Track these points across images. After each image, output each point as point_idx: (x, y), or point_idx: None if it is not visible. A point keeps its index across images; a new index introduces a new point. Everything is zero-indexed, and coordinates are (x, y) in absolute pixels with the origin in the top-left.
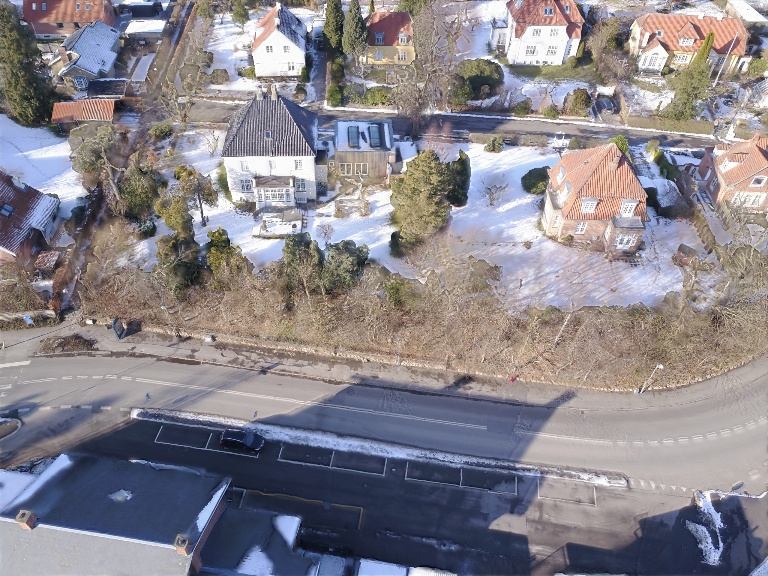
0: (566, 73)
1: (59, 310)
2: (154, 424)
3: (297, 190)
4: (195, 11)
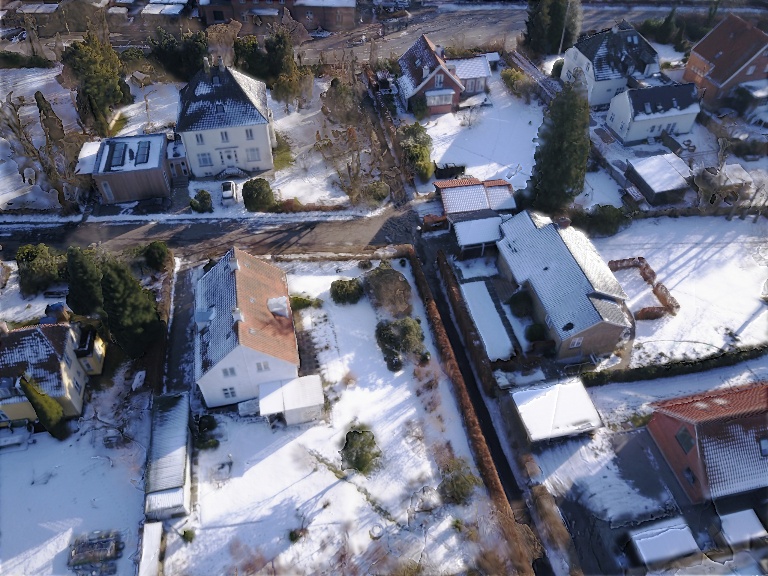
0: None
1: None
2: None
3: None
4: None
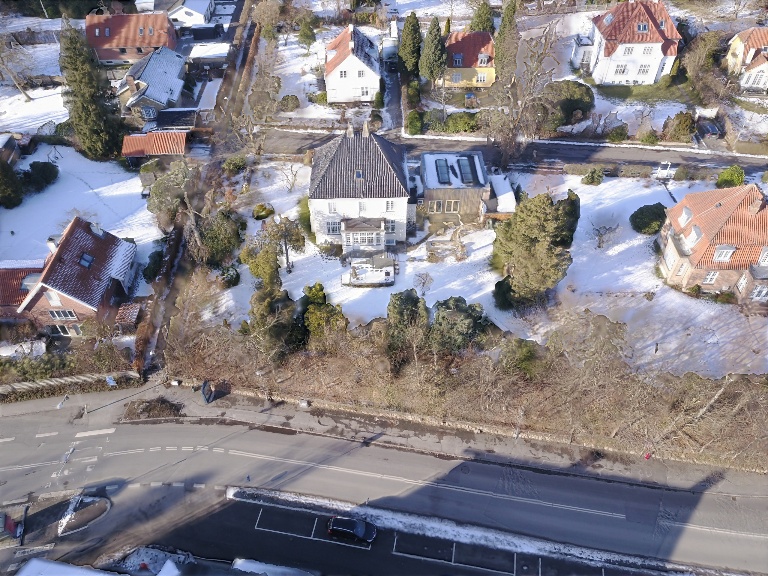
0: (660, 93)
1: (142, 369)
2: (253, 506)
3: (386, 232)
4: (258, 32)
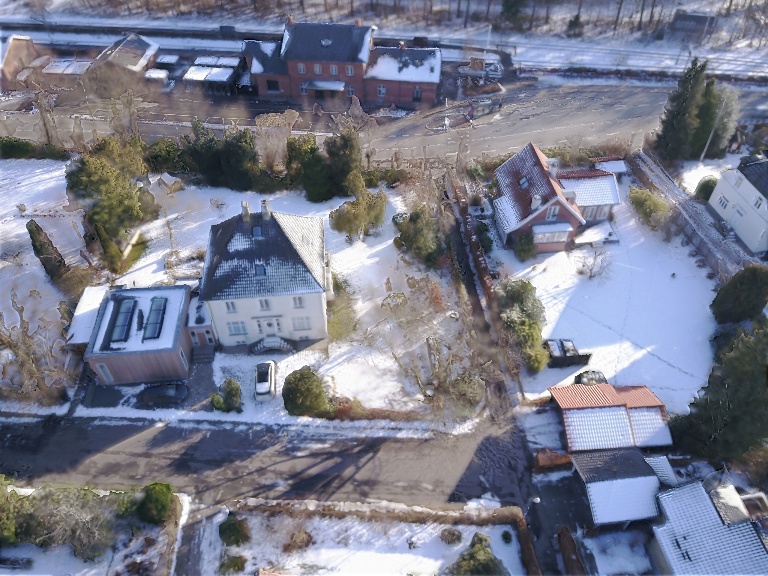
0: None
1: None
2: None
3: None
4: None
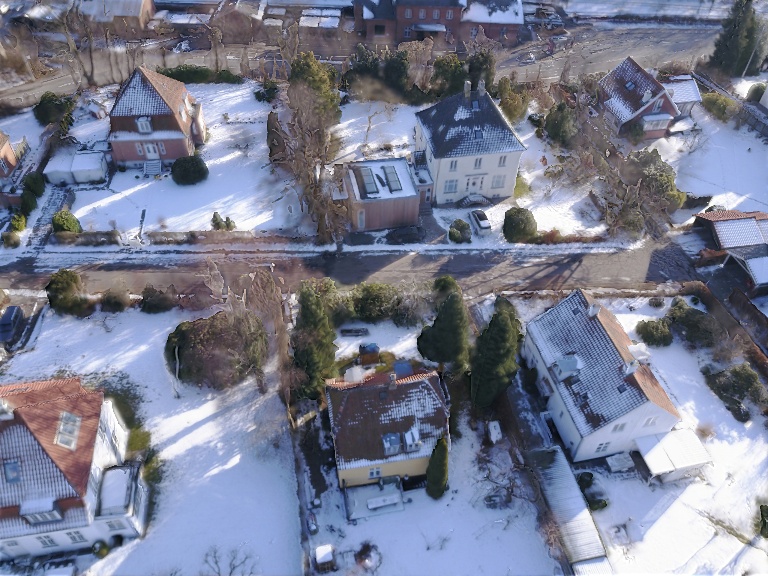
0: None
1: None
2: None
3: None
4: None
